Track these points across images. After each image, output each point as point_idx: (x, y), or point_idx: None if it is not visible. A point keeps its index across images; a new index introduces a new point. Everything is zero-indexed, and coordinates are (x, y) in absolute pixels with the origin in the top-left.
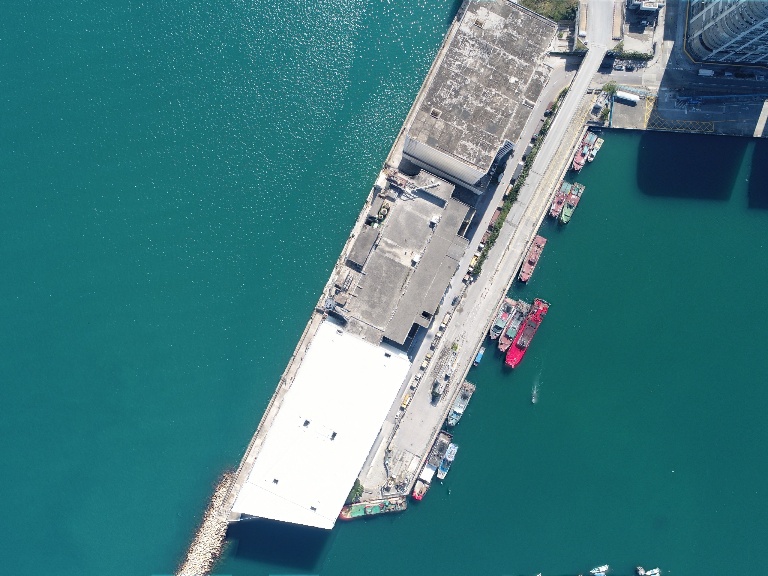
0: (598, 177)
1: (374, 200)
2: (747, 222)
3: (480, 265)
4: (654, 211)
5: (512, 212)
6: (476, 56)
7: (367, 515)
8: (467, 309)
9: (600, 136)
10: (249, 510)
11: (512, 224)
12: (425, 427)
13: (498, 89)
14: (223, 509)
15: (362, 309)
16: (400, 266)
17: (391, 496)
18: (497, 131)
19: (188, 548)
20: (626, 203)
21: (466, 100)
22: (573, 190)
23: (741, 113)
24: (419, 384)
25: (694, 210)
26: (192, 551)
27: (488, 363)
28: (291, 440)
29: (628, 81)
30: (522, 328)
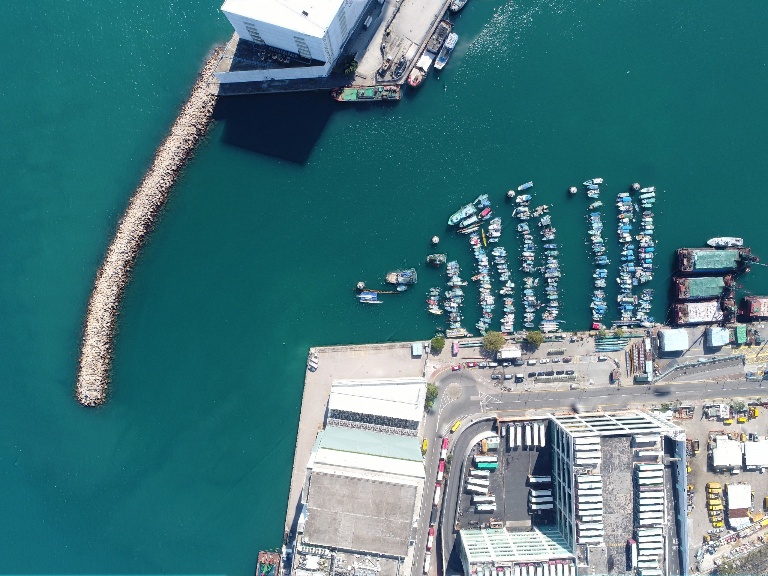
0: None
1: None
2: None
3: None
4: None
5: None
6: None
7: (359, 103)
8: None
9: None
10: (239, 9)
11: None
12: (426, 14)
13: None
14: (212, 81)
15: None
16: None
17: (385, 83)
18: None
19: (173, 123)
20: None
21: None
22: None
23: None
24: None
25: None
26: (177, 124)
27: None
28: None
29: None
30: None
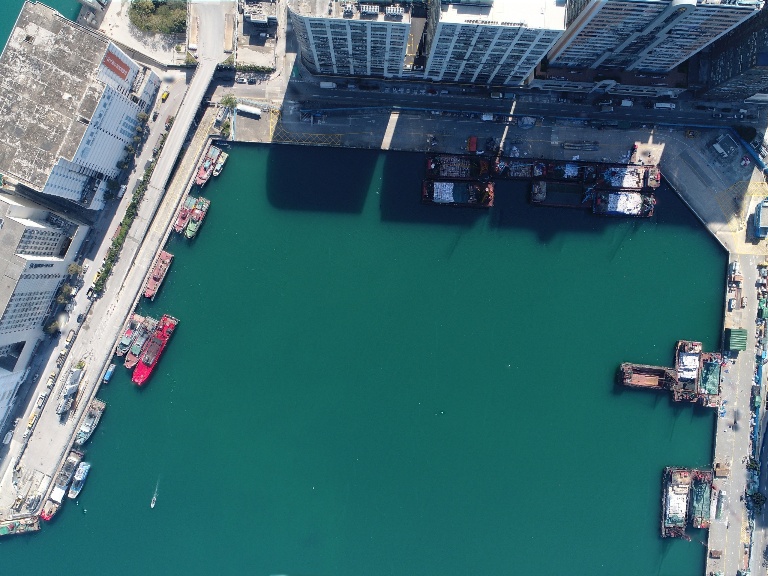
0: (225, 191)
1: None
2: (381, 235)
3: (98, 282)
4: (285, 225)
5: (134, 227)
6: (27, 72)
7: None
8: (93, 326)
9: (227, 150)
10: None
11: (135, 240)
12: (55, 446)
13: (51, 106)
14: None
15: None
16: None
17: (22, 516)
18: (52, 148)
19: None
20: (256, 217)
21: (19, 117)
22: (197, 205)
23: (368, 125)
24: (47, 403)
25: (326, 223)
26: None
27: (119, 380)
28: None
29: (251, 94)
30: None
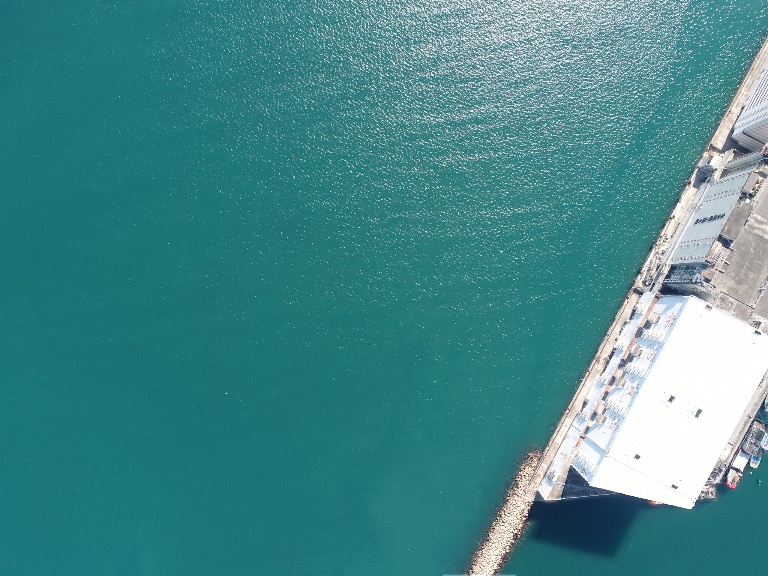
0: None
1: (750, 175)
2: None
3: None
4: None
5: None
6: None
7: None
8: None
9: None
10: (609, 485)
11: None
12: None
13: None
14: (529, 489)
15: (728, 285)
16: None
17: None
18: None
19: (488, 527)
20: None
21: None
22: None
23: None
24: None
25: None
26: (494, 530)
27: None
28: (655, 415)
29: None
30: None
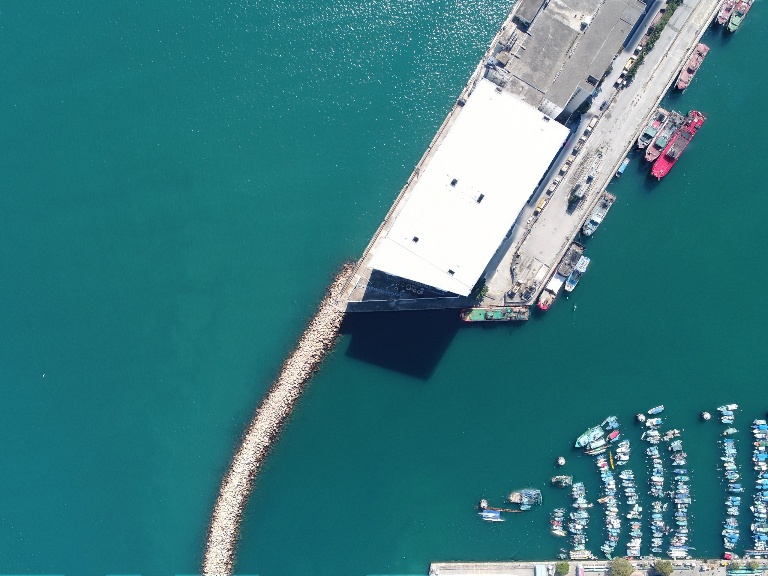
0: None
1: None
2: None
3: (637, 66)
4: None
5: (676, 15)
6: None
7: (486, 322)
8: (615, 115)
9: None
10: (385, 266)
11: (674, 28)
12: (557, 236)
13: None
14: (341, 299)
15: (523, 71)
16: (568, 29)
17: (514, 304)
18: None
19: (300, 336)
20: None
21: None
22: None
23: None
24: (556, 189)
25: None
26: (304, 339)
27: (631, 176)
28: (436, 198)
29: None
30: (673, 140)
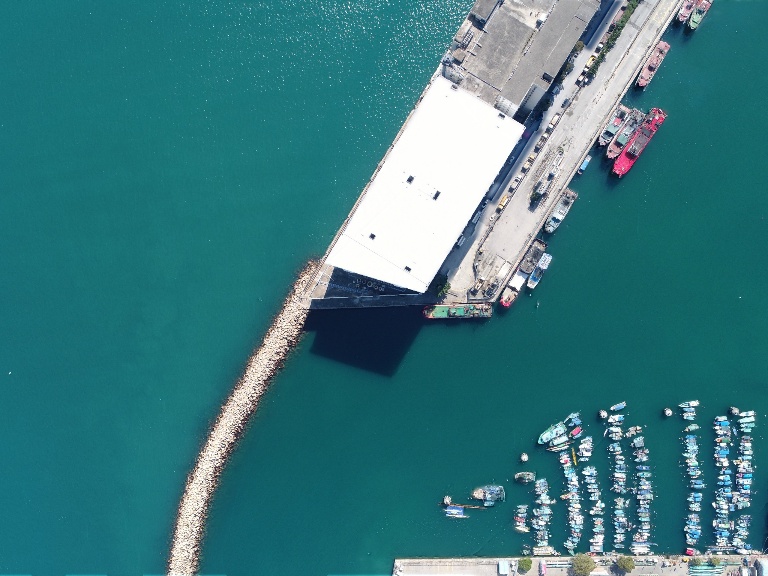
0: None
1: None
2: None
3: (597, 63)
4: None
5: (637, 13)
6: None
7: (450, 319)
8: (577, 113)
9: None
10: (342, 263)
11: (635, 26)
12: (520, 233)
13: None
14: (305, 296)
15: (479, 69)
16: (524, 27)
17: (477, 301)
18: None
19: (265, 334)
20: (760, 16)
21: None
22: None
23: None
24: (518, 187)
25: None
26: (269, 336)
27: (593, 173)
28: (393, 195)
29: None
30: (634, 137)
